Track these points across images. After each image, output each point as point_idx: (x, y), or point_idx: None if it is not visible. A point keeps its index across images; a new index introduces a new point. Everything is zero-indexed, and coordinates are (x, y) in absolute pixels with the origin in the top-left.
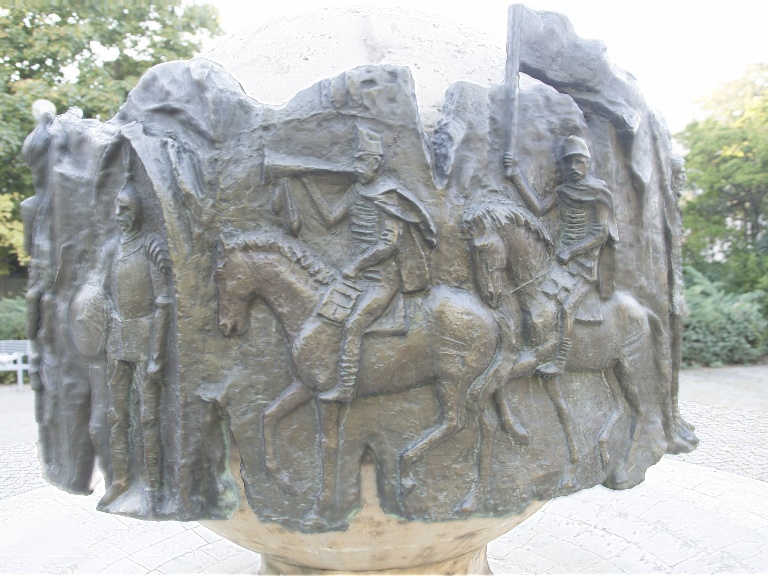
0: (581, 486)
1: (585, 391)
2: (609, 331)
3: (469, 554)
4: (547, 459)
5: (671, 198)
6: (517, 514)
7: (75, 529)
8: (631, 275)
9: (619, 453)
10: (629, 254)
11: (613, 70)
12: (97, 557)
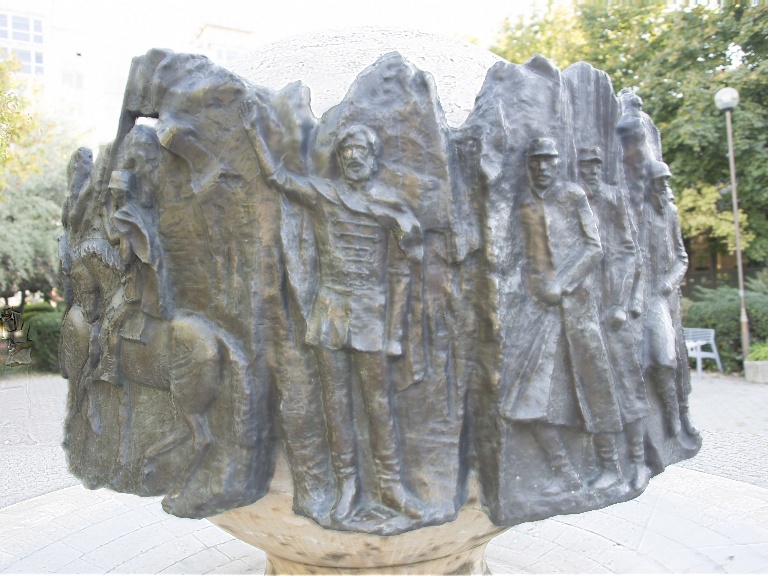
0: (122, 488)
1: (150, 406)
2: (156, 351)
3: (327, 571)
4: (106, 453)
5: (300, 192)
6: (251, 527)
7: None
8: (204, 294)
9: (173, 476)
10: (199, 271)
11: (172, 84)
12: None
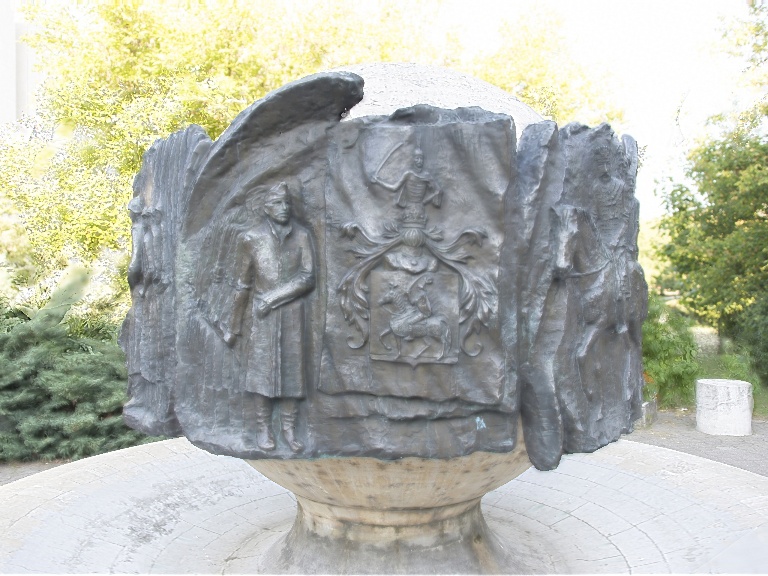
0: None
1: None
2: None
3: None
4: None
5: None
6: None
7: (752, 571)
8: None
9: None
10: None
11: None
12: (691, 572)
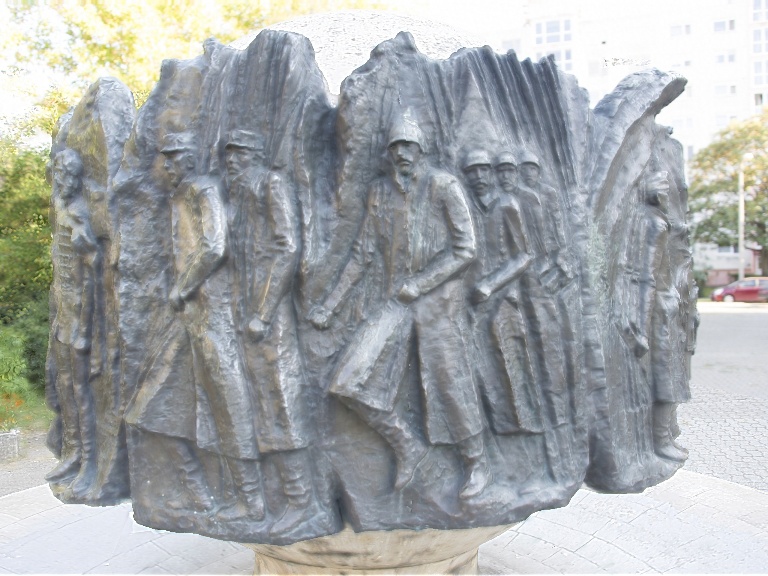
0: None
1: None
2: None
3: None
4: None
5: None
6: None
7: None
8: None
9: None
10: None
11: None
12: None
